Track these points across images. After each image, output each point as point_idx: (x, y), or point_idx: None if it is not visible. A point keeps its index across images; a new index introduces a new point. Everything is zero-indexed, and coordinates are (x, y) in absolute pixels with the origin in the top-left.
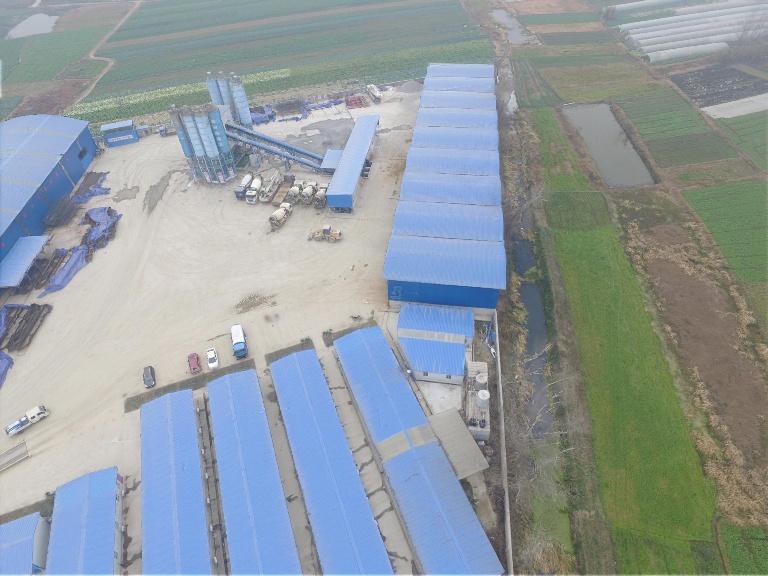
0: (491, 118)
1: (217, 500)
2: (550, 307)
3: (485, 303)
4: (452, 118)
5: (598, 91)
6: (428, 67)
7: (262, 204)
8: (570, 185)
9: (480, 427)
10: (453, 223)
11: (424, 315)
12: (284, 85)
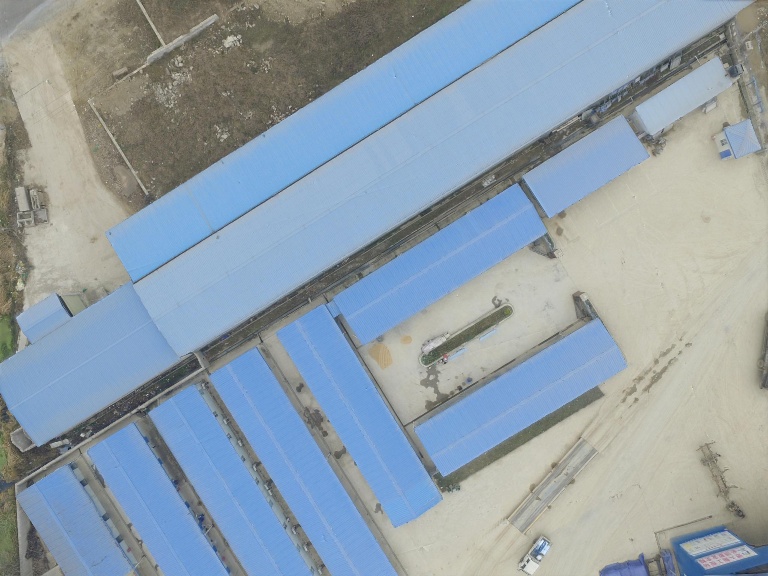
0: None
1: None
2: None
3: None
4: None
5: None
6: None
7: None
8: None
9: None
10: None
11: None
12: None
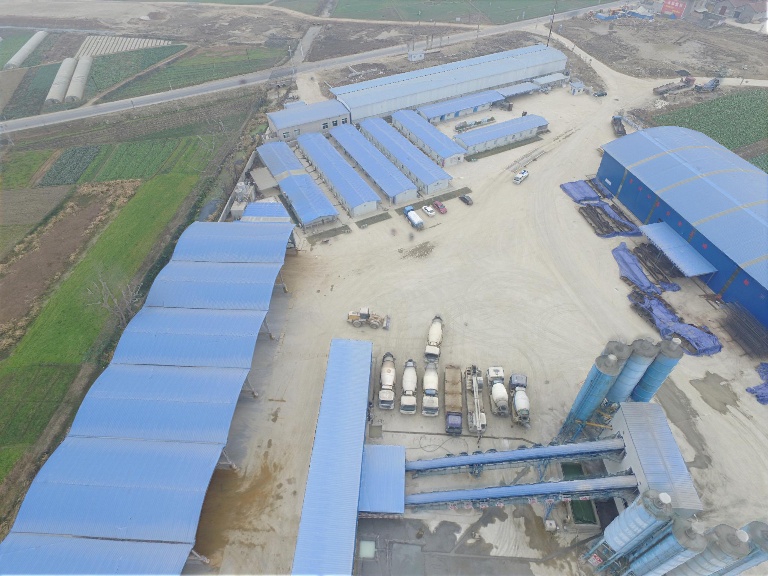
0: None
1: None
2: (156, 266)
3: None
4: (92, 570)
5: None
6: None
7: None
8: None
9: (248, 183)
10: (214, 272)
11: None
12: None
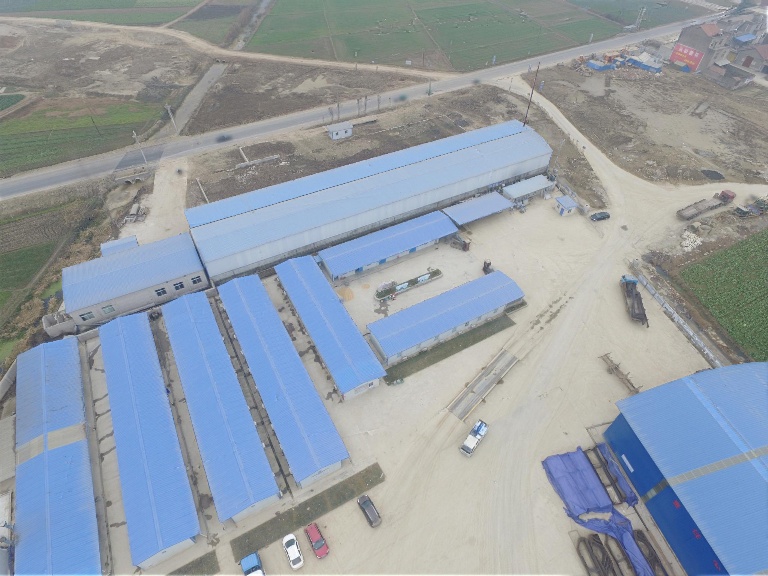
0: None
1: (252, 393)
2: None
3: None
4: None
5: None
6: None
7: None
8: None
9: None
10: None
11: None
12: None
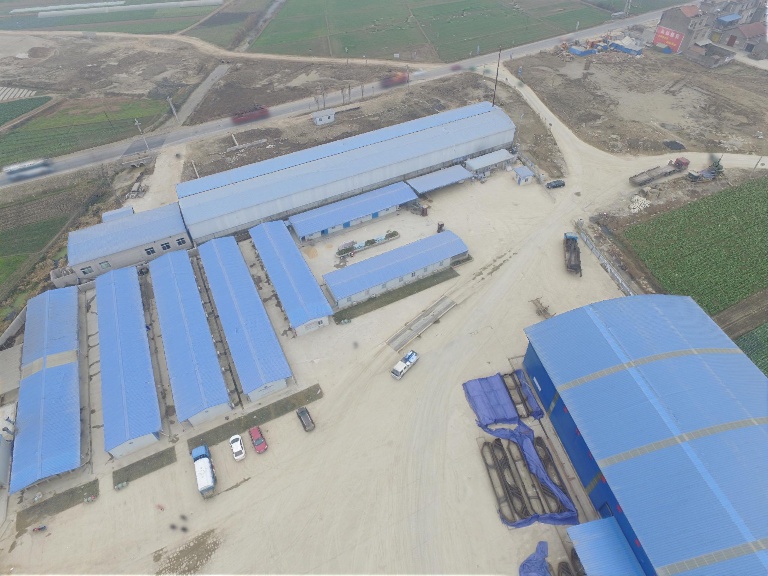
0: None
1: (219, 330)
2: None
3: None
4: None
5: None
6: None
7: None
8: None
9: None
10: None
11: None
12: None
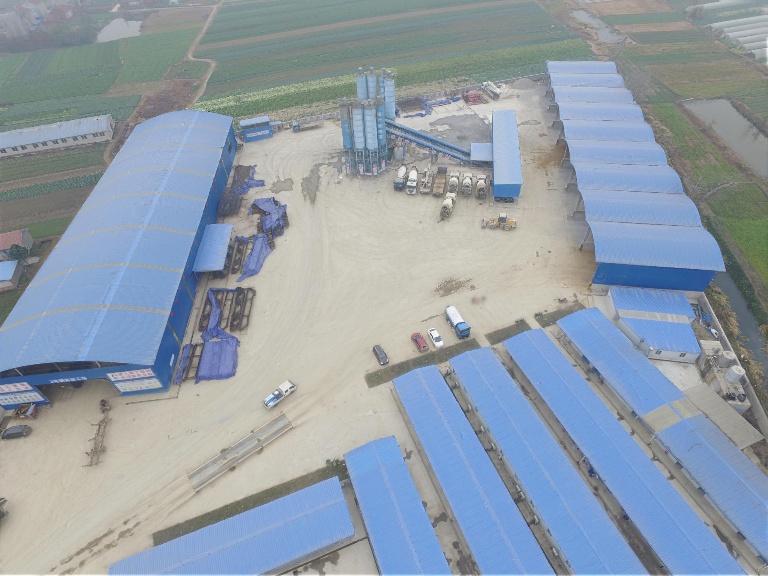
0: (635, 111)
1: None
2: (751, 291)
3: (695, 286)
4: (596, 112)
5: (713, 87)
6: (548, 64)
7: (421, 195)
8: (721, 176)
9: (740, 401)
10: (646, 209)
11: (637, 297)
12: (396, 83)
